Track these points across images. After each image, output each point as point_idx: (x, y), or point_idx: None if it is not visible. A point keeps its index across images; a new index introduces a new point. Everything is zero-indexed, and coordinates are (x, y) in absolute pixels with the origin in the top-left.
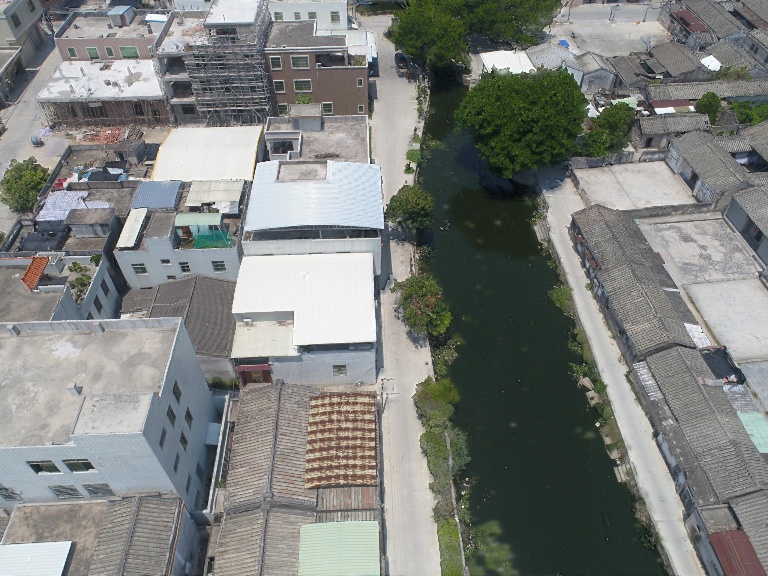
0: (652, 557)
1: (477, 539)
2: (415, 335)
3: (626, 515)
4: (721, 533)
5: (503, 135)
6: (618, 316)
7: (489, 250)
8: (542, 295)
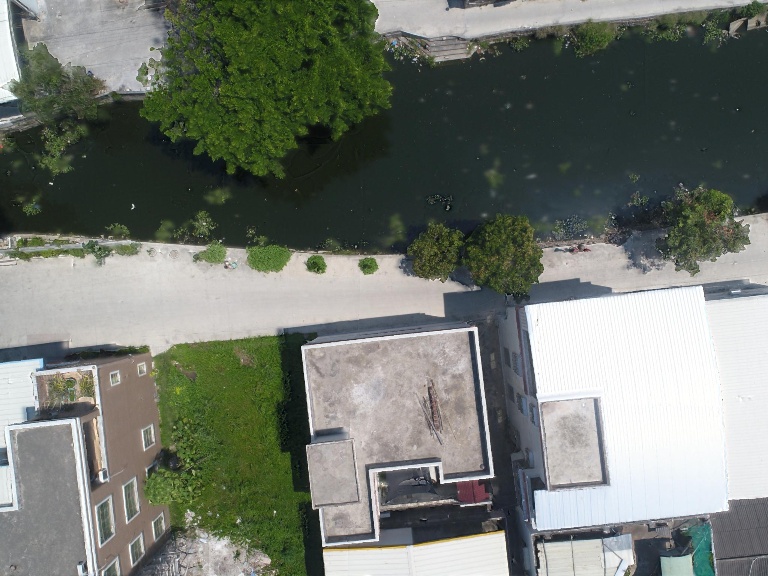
0: None
1: None
2: None
3: None
4: None
5: (354, 80)
6: None
7: (496, 135)
8: (586, 65)
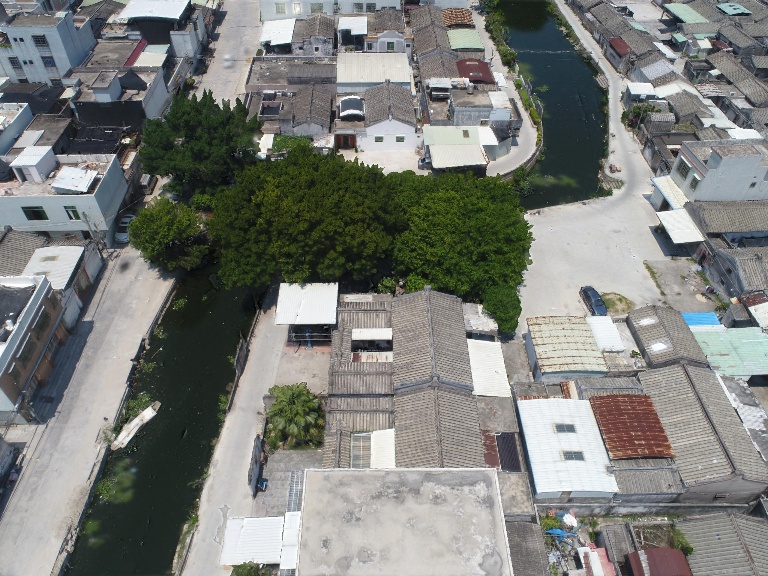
0: (589, 73)
1: (515, 59)
2: (483, 3)
3: (578, 56)
4: (613, 39)
5: None
6: (578, 1)
7: None
8: (542, 9)
